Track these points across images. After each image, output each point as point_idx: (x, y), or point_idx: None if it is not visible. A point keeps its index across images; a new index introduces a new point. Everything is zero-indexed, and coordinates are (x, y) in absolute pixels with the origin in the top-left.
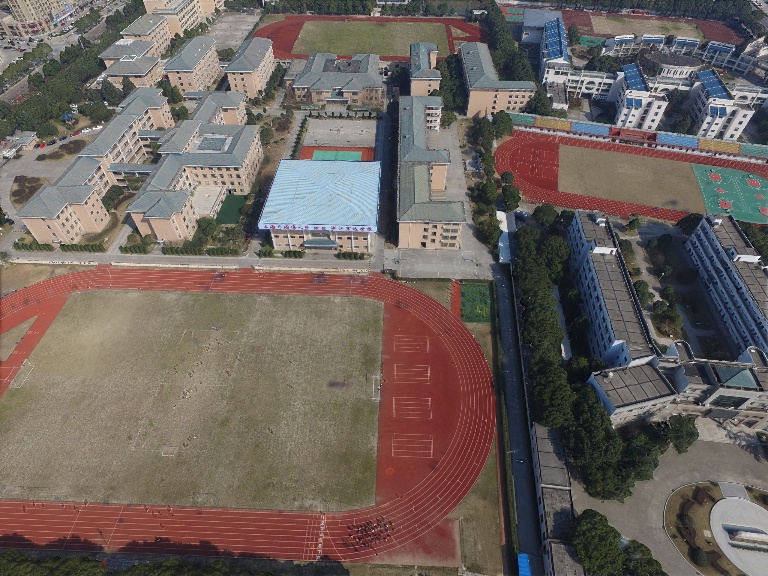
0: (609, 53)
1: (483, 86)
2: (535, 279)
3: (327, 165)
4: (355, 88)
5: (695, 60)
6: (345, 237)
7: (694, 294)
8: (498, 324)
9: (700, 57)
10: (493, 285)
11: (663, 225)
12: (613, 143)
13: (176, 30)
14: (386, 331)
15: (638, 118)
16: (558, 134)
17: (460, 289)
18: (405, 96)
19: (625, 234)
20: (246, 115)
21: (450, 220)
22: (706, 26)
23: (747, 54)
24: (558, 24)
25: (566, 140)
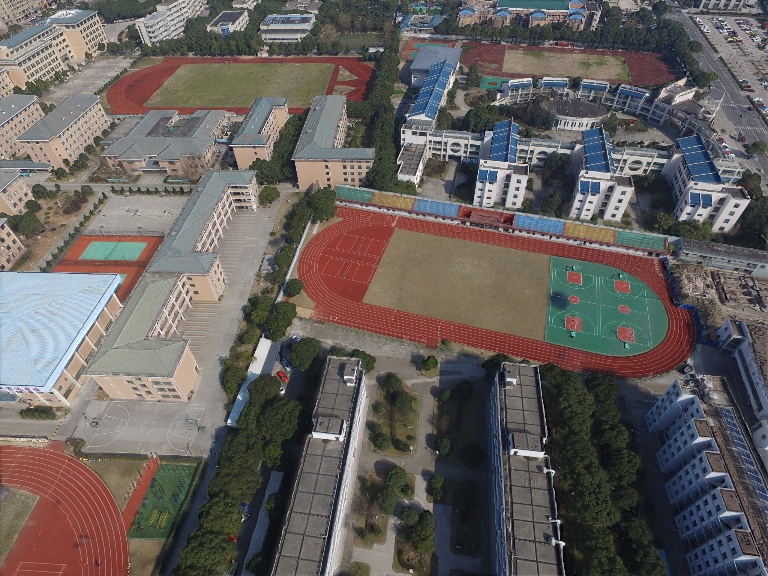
0: (504, 99)
1: (308, 156)
2: (226, 478)
3: (45, 281)
4: (170, 157)
5: (600, 108)
6: (26, 391)
7: (469, 490)
8: (170, 544)
9: (611, 103)
10: (197, 469)
11: (478, 358)
12: (462, 226)
13: (22, 82)
14: (13, 553)
15: (499, 192)
16: (399, 214)
17: (154, 474)
18: (209, 171)
19: (421, 374)
20: (29, 194)
21: (152, 373)
22: (636, 60)
23: (662, 100)
24: (441, 68)
25: (406, 222)
